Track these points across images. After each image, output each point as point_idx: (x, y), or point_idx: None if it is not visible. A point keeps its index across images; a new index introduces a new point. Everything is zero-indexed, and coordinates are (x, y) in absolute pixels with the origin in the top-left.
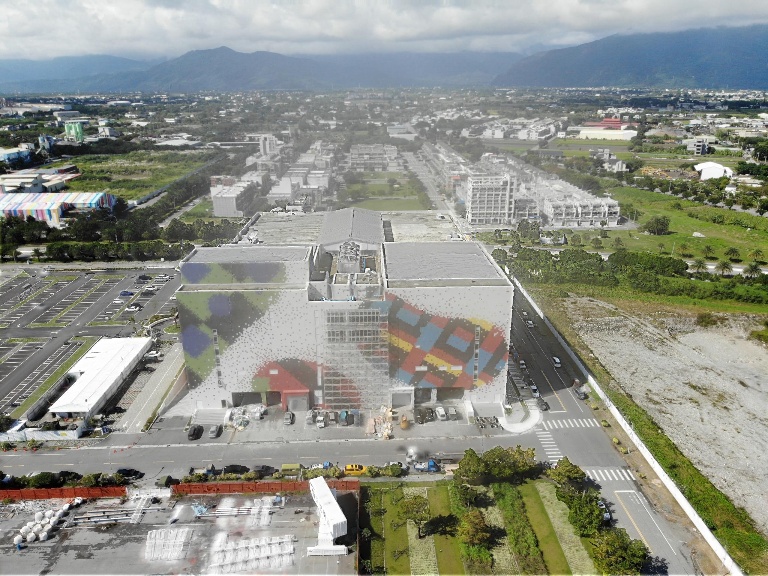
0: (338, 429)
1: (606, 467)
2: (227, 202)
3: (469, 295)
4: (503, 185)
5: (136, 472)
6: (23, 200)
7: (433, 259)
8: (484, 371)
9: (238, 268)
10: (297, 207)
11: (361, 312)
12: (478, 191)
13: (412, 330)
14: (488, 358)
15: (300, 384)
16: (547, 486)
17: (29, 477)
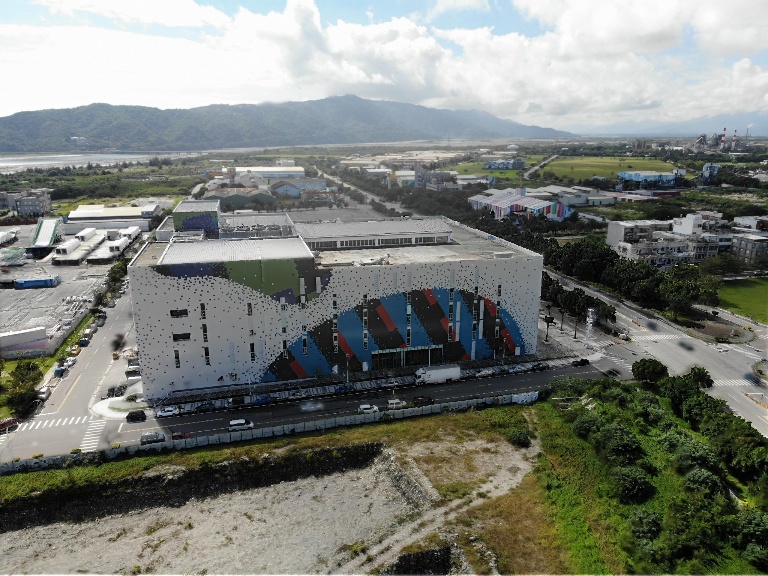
0: None
1: (1, 450)
2: (618, 230)
3: None
4: None
5: (111, 304)
6: None
7: None
8: None
9: None
10: (627, 245)
11: None
12: None
13: None
14: None
15: None
16: None
17: None
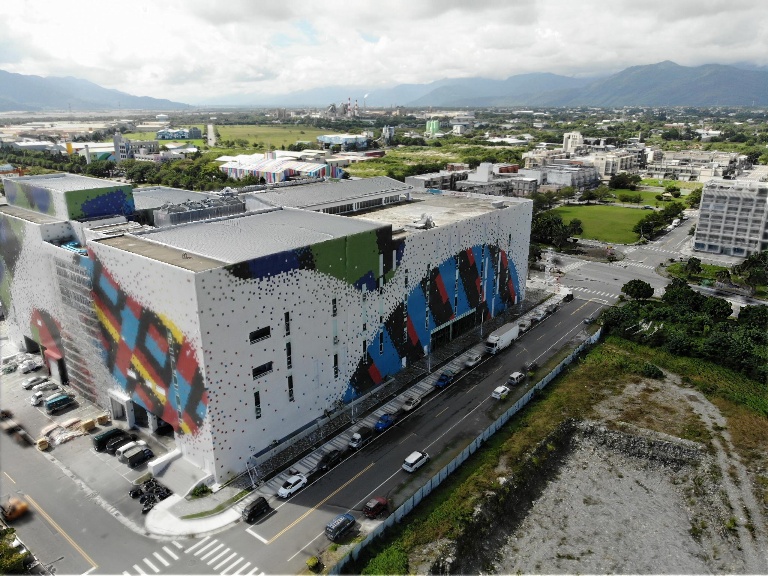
0: (39, 414)
1: None
2: (417, 184)
3: (153, 273)
4: (759, 195)
5: None
6: (272, 165)
7: None
8: (186, 410)
9: (29, 192)
10: None
11: (76, 268)
12: (712, 200)
13: (115, 311)
14: (187, 390)
15: (56, 346)
16: None
17: None
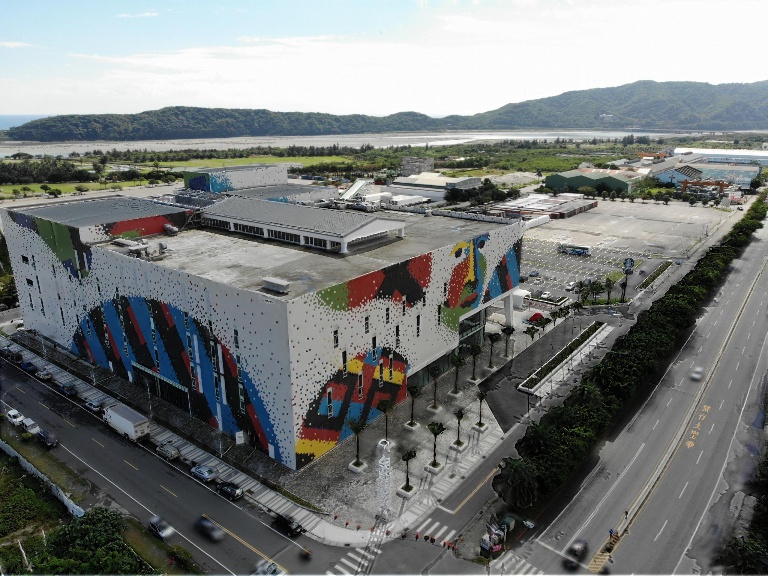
0: None
1: None
2: None
3: None
4: None
5: None
6: None
7: None
8: None
9: None
10: None
11: None
12: None
13: None
14: None
15: None
16: None
17: None
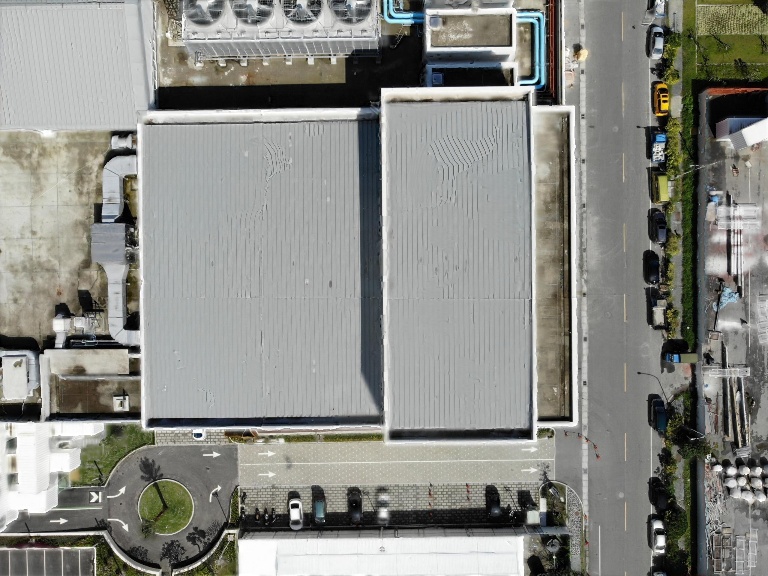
0: None
1: None
2: None
3: None
4: None
5: (660, 405)
6: None
7: None
8: None
9: None
10: None
11: None
12: None
13: None
14: None
15: None
16: None
17: (667, 547)
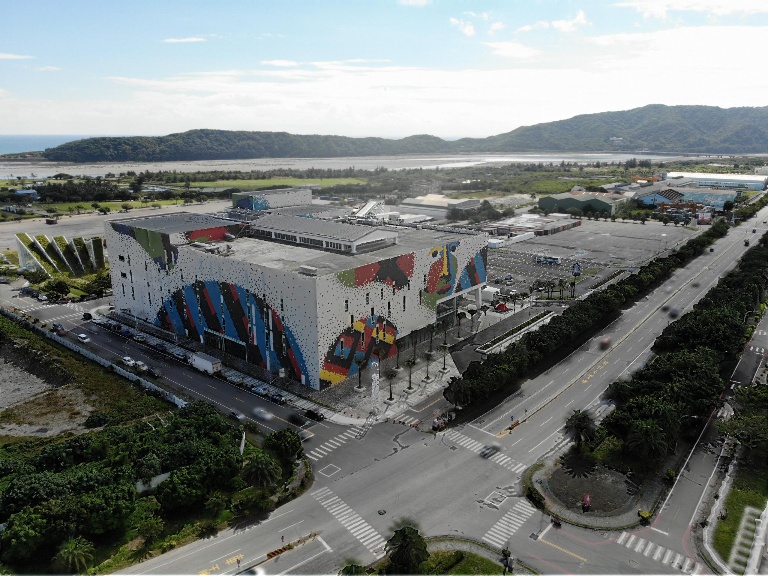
0: None
1: None
2: None
3: None
4: None
5: None
6: None
7: (186, 222)
8: None
9: None
10: None
11: None
12: None
13: None
14: None
15: None
16: (74, 296)
17: None
